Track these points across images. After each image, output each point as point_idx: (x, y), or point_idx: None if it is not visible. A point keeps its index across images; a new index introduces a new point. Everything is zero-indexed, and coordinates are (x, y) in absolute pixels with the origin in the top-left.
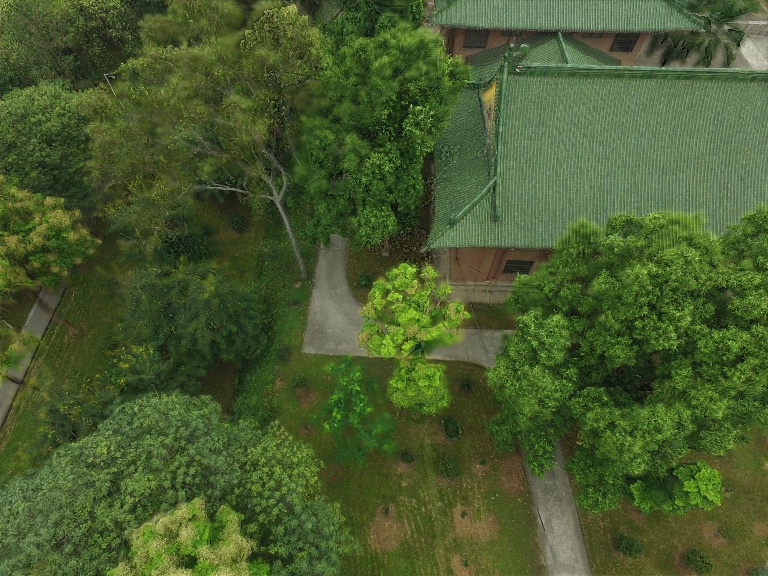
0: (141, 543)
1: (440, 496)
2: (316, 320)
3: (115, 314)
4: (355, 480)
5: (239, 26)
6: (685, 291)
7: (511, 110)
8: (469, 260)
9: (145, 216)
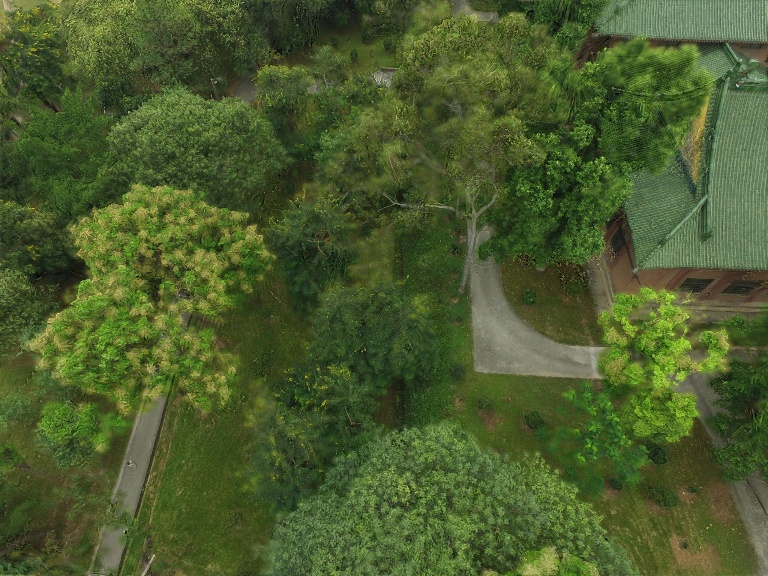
0: None
1: (653, 525)
2: (482, 337)
3: (258, 328)
4: None
5: (330, 30)
6: None
7: (723, 126)
8: (647, 278)
9: (306, 229)
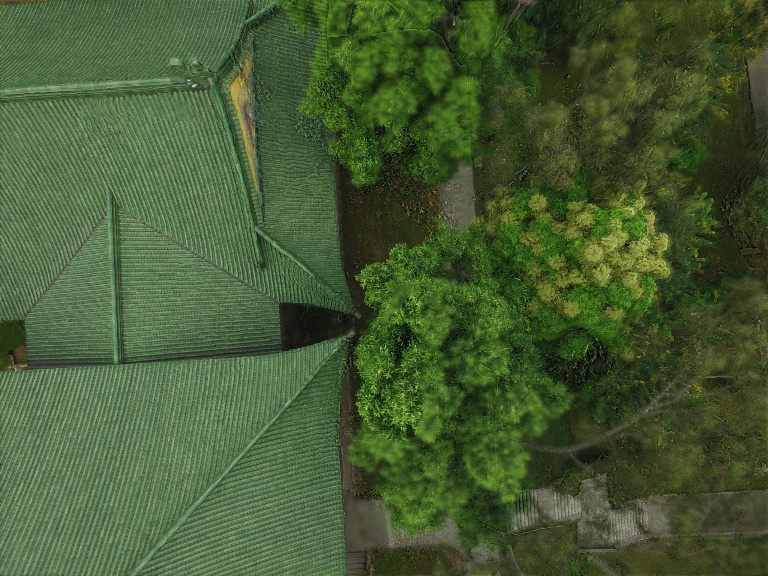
0: None
1: None
2: None
3: None
4: None
5: None
6: None
7: None
8: None
9: None
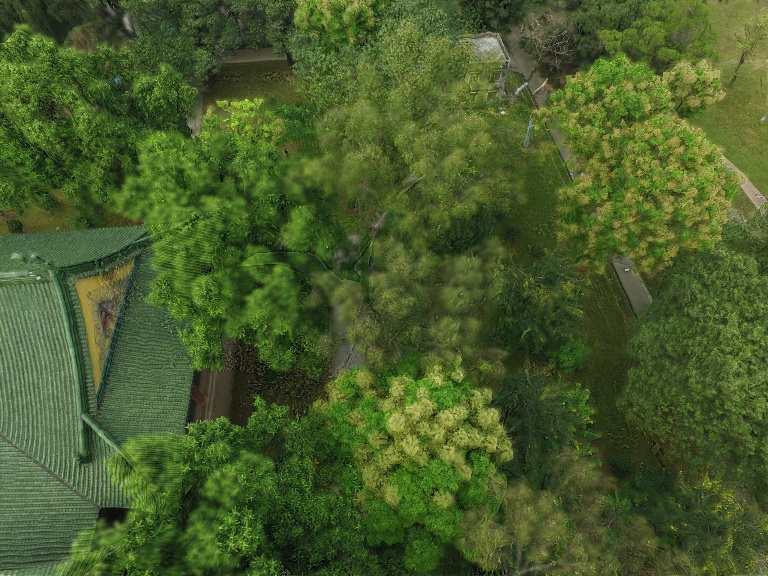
0: (364, 4)
1: None
2: None
3: None
4: (308, 167)
5: None
6: None
7: None
8: None
9: None
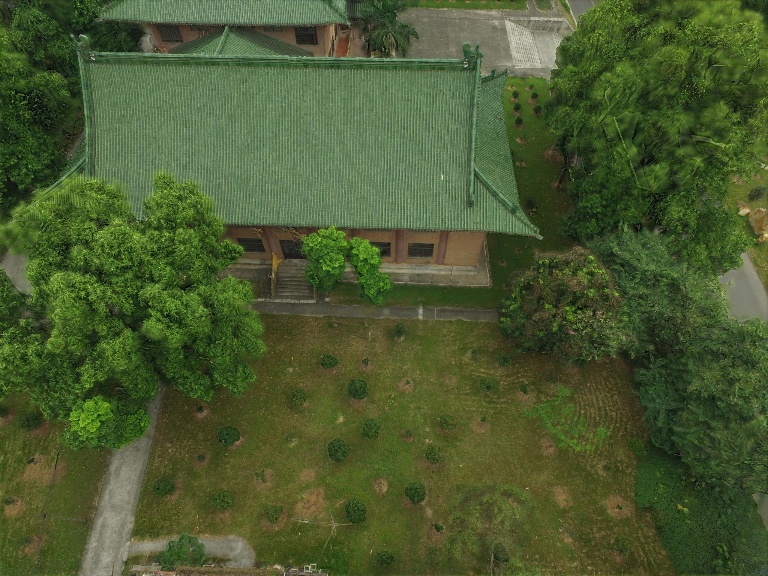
0: None
1: (23, 446)
2: None
3: None
4: None
5: None
6: (61, 244)
7: (99, 95)
8: None
9: None
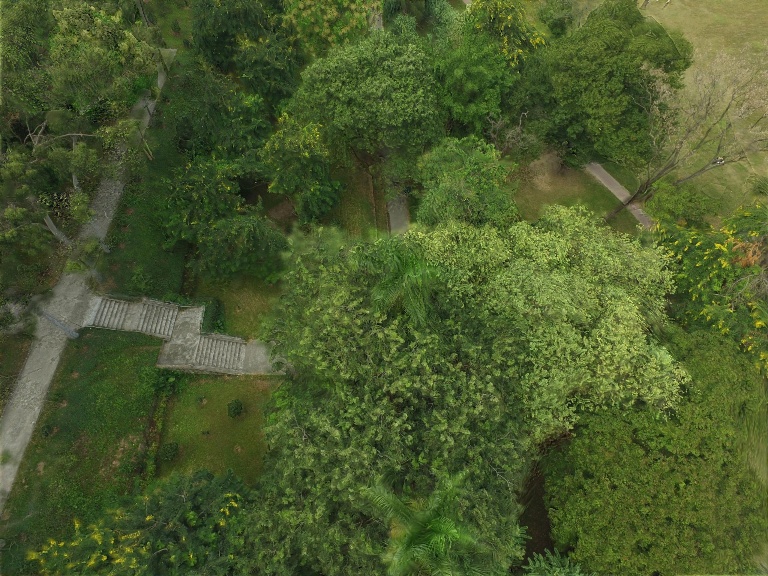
0: None
1: None
2: (167, 62)
3: None
4: None
5: None
6: None
7: None
8: None
9: None
